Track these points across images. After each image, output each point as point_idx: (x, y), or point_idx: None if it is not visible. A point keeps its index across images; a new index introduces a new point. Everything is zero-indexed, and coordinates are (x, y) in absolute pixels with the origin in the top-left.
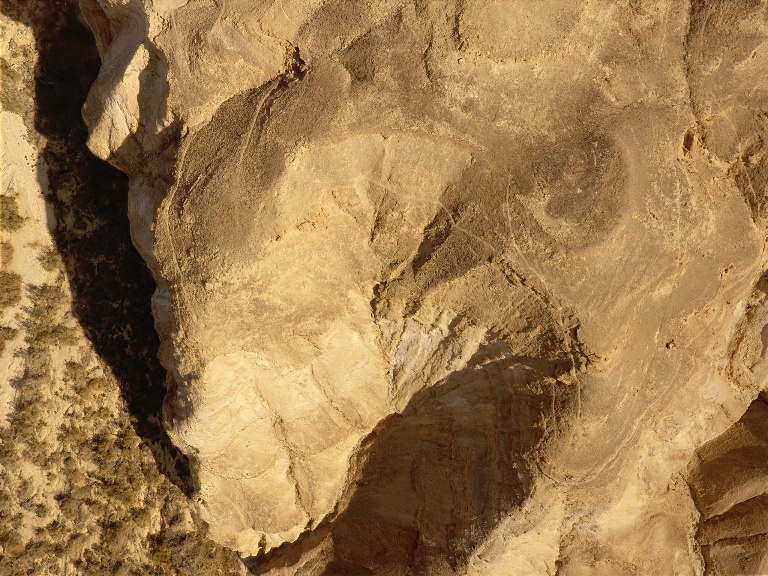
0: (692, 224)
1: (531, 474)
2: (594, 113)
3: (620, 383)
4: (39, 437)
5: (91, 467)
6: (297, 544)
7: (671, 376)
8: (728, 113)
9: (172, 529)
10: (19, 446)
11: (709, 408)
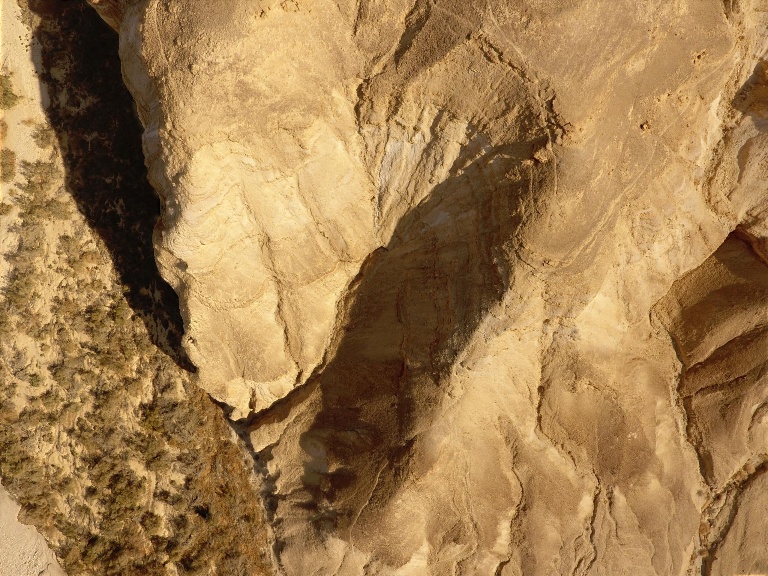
0: None
1: (510, 264)
2: None
3: (595, 156)
4: (33, 309)
5: (84, 338)
6: (287, 402)
7: (646, 160)
8: None
9: (164, 396)
10: (13, 318)
11: (686, 221)
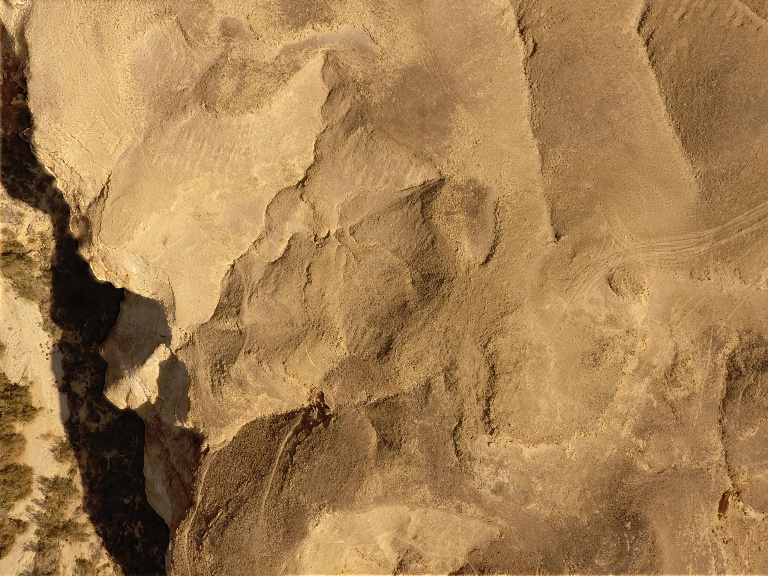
0: None
1: None
2: (627, 485)
3: None
4: None
5: None
6: None
7: None
8: (764, 474)
9: None
10: None
11: None
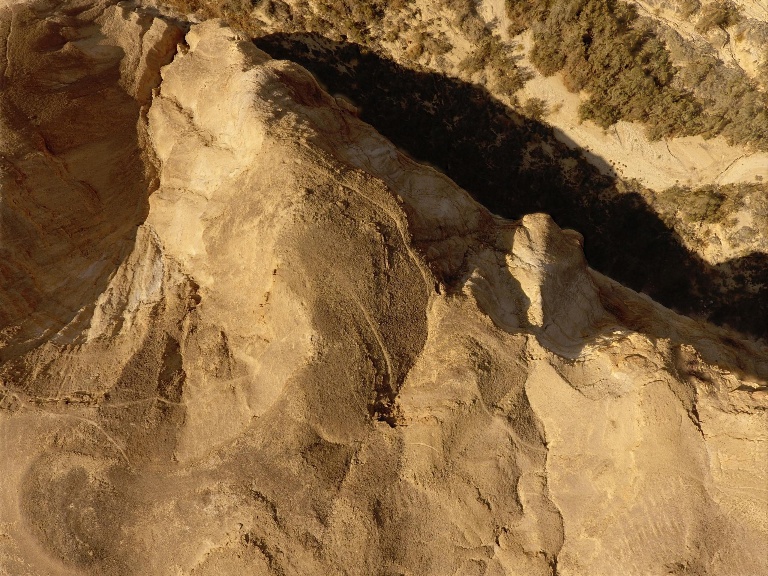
0: None
1: None
2: (116, 575)
3: None
4: None
5: None
6: None
7: None
8: None
9: (266, 1)
10: None
11: None
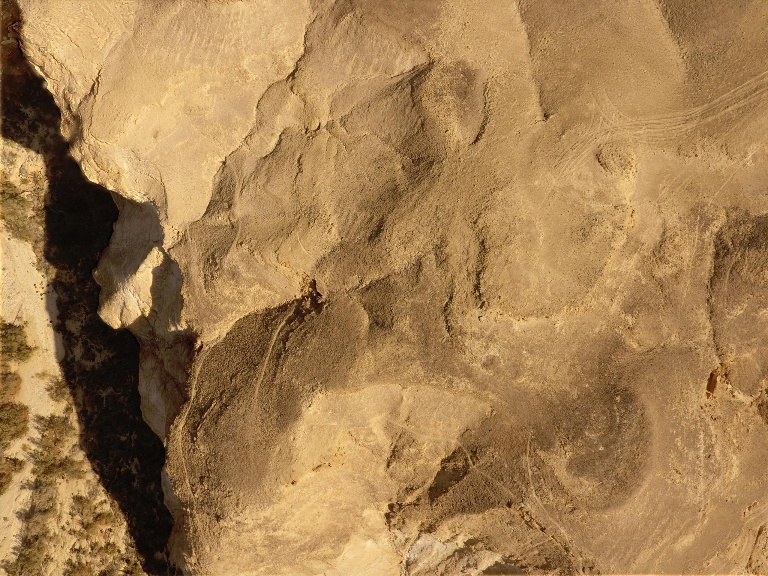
0: (716, 474)
1: None
2: (616, 362)
3: None
4: (45, 572)
5: None
6: None
7: None
8: (752, 354)
9: None
10: None
11: None
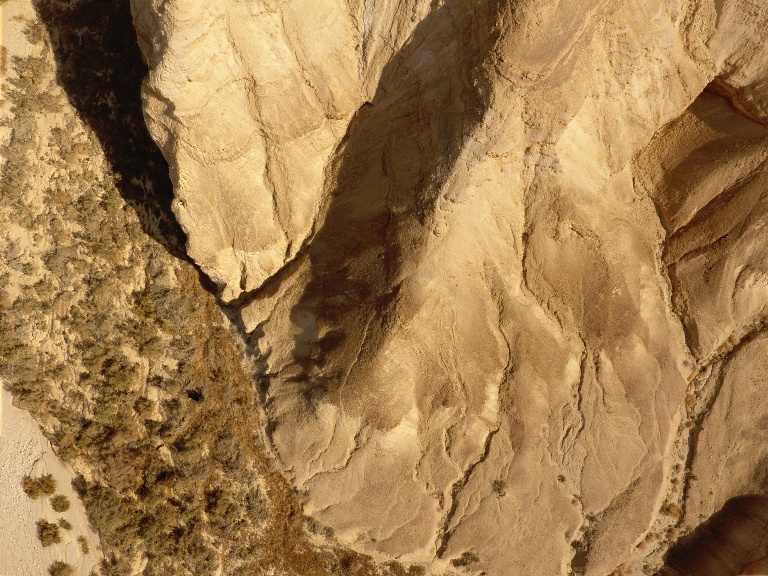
0: None
1: (490, 81)
2: None
3: None
4: (25, 200)
5: (77, 228)
6: (277, 280)
7: None
8: None
9: (156, 282)
10: (6, 209)
11: (664, 57)
